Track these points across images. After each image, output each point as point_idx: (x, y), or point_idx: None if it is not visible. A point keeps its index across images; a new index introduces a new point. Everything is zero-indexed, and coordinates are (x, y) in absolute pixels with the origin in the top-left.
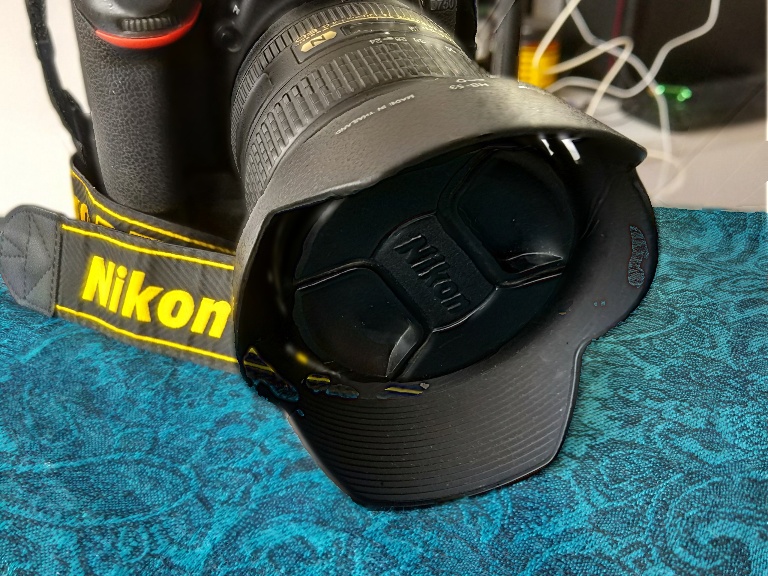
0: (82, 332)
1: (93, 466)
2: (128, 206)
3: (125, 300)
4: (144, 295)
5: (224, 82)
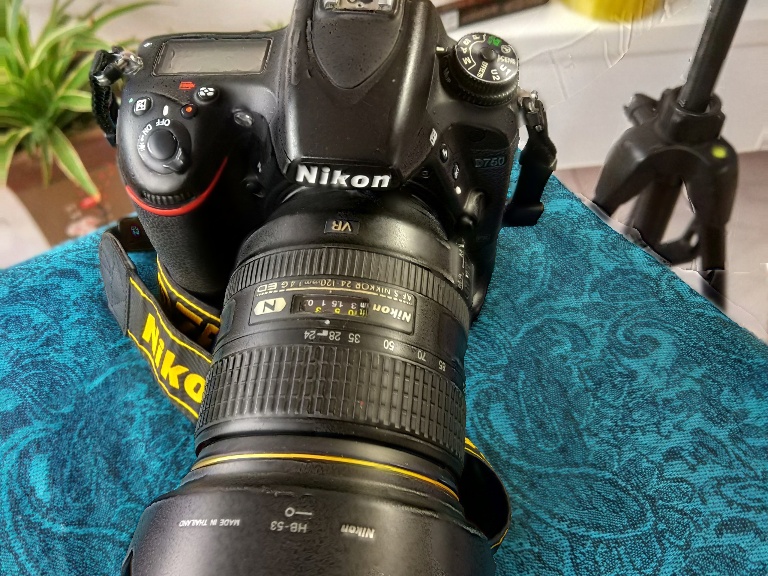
0: (139, 365)
1: (91, 537)
2: (176, 282)
3: (162, 366)
4: (174, 369)
5: (255, 210)
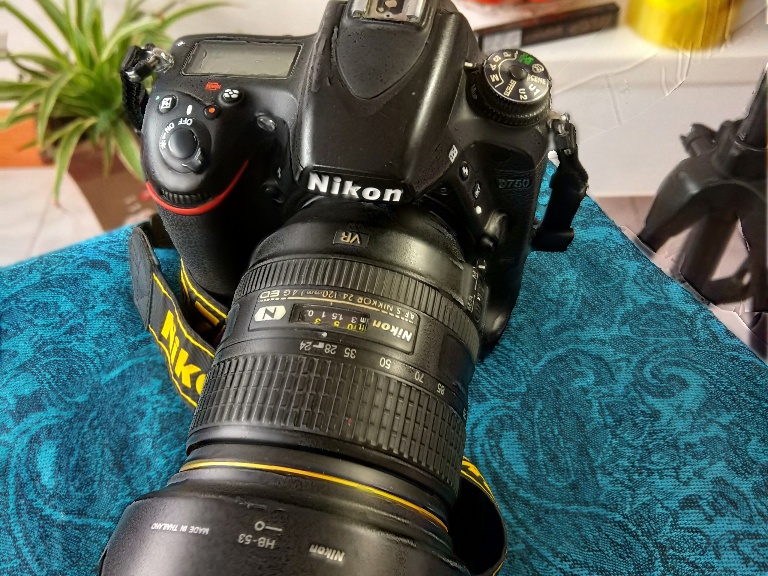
0: (156, 360)
1: (89, 528)
2: (196, 282)
3: (176, 363)
4: (187, 368)
5: (275, 216)
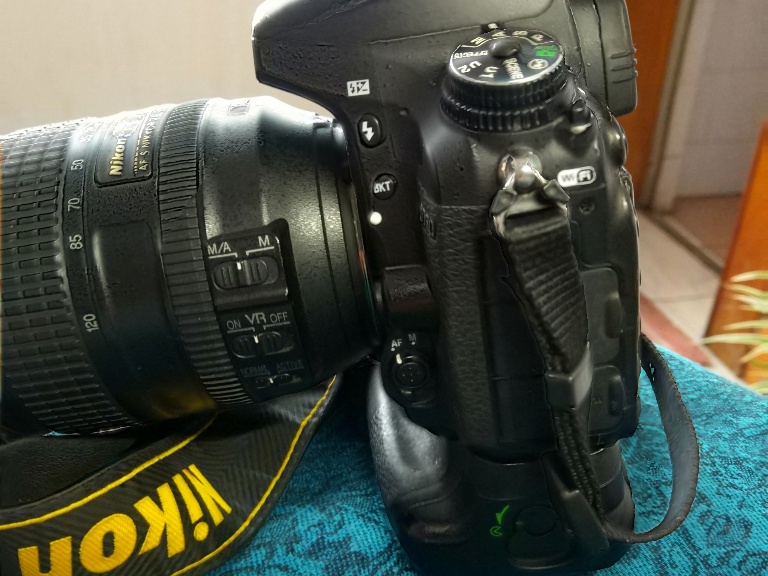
0: None
1: None
2: None
3: None
4: None
5: None
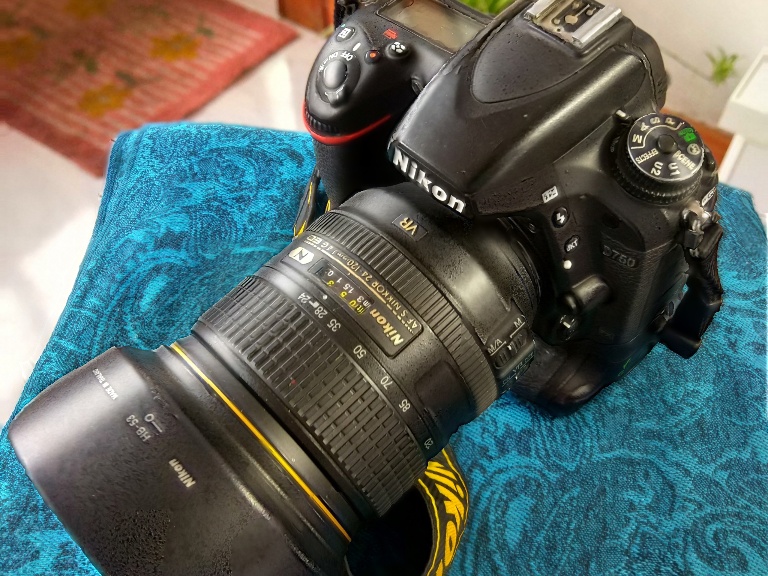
0: None
1: None
2: None
3: None
4: None
5: (403, 179)
